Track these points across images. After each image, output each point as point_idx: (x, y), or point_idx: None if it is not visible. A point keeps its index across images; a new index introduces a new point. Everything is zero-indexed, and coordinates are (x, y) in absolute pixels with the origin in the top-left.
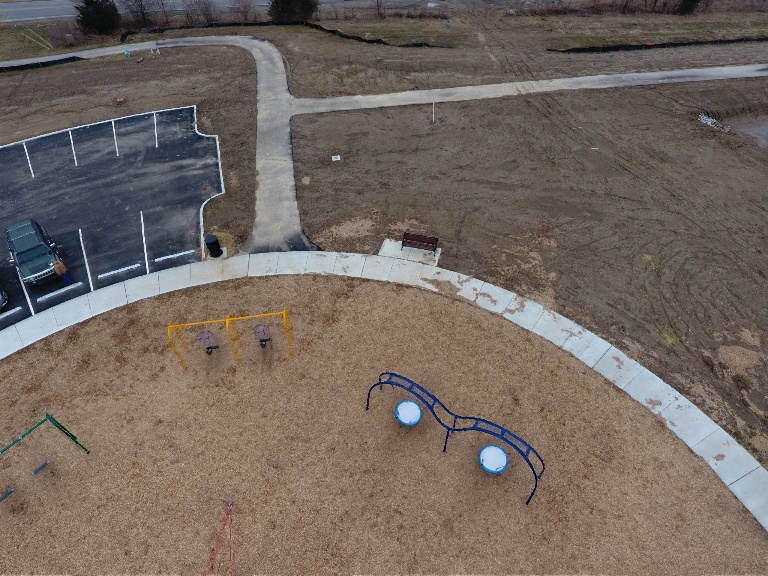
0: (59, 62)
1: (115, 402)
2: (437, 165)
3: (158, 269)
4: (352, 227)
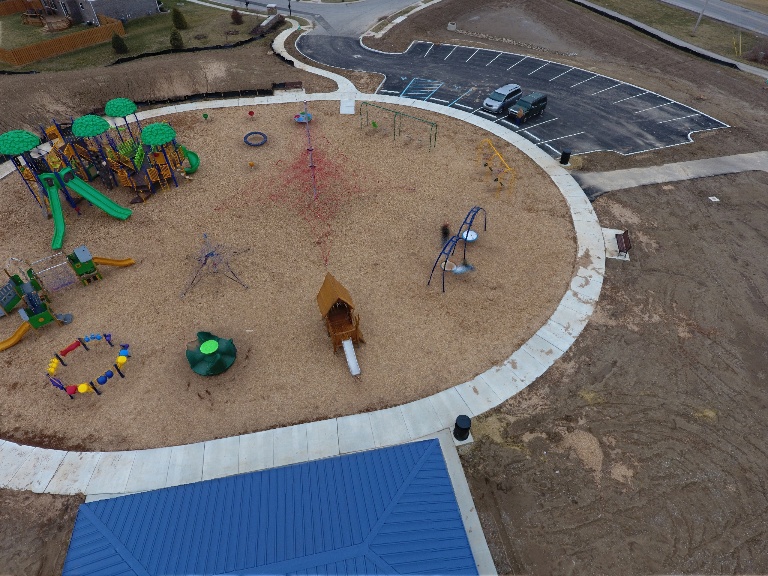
0: (722, 63)
1: (454, 152)
2: (759, 260)
3: (540, 146)
4: (625, 213)
